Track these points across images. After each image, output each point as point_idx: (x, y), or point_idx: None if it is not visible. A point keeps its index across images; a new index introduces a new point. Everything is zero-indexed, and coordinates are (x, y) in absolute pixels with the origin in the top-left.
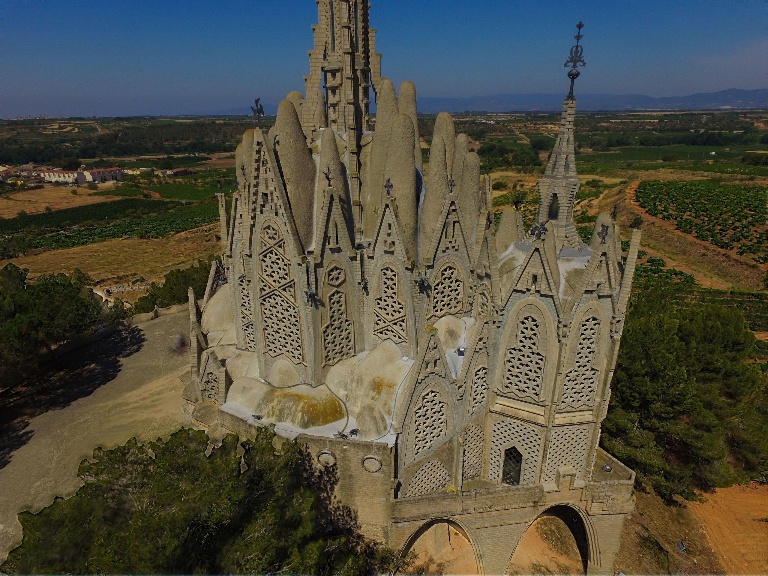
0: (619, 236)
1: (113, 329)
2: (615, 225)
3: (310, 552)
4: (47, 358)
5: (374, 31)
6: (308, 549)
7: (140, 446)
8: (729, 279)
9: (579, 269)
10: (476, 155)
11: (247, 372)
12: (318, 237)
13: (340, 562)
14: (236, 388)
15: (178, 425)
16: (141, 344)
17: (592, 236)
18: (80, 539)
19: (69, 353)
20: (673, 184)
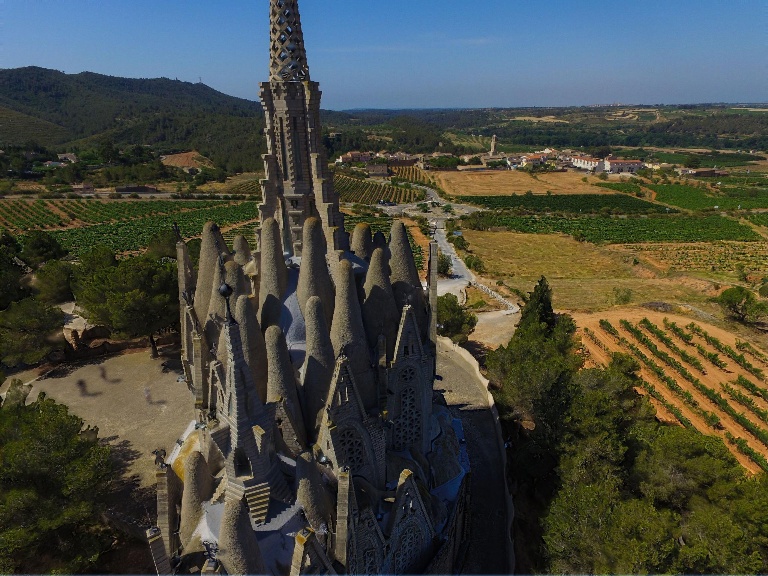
0: (299, 561)
1: None
2: (296, 539)
3: None
4: None
5: (315, 156)
6: None
7: (63, 411)
8: None
9: (200, 541)
10: (272, 331)
11: None
12: None
13: (72, 569)
14: None
15: None
16: None
17: None
18: (4, 434)
19: None
20: None
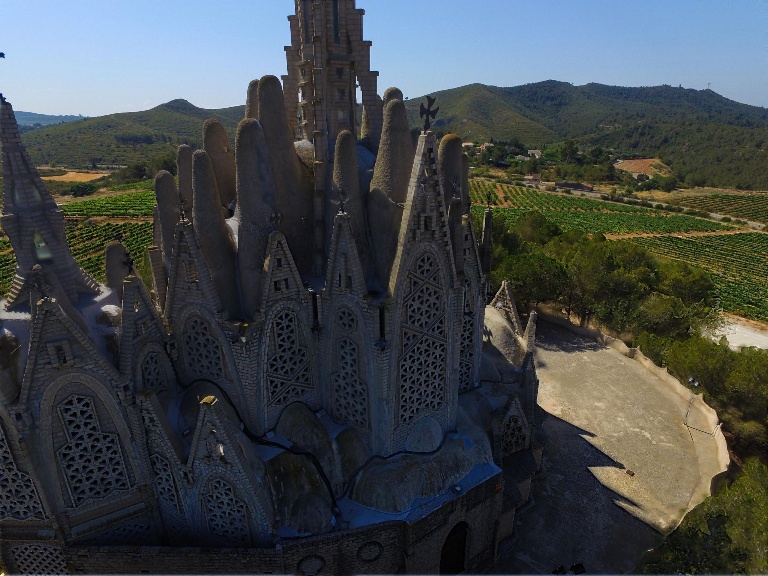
0: None
1: (595, 336)
2: None
3: None
4: (543, 316)
5: None
6: None
7: None
8: None
9: None
10: None
11: None
12: None
13: None
14: None
15: None
16: (560, 351)
17: None
18: None
19: (555, 325)
20: None
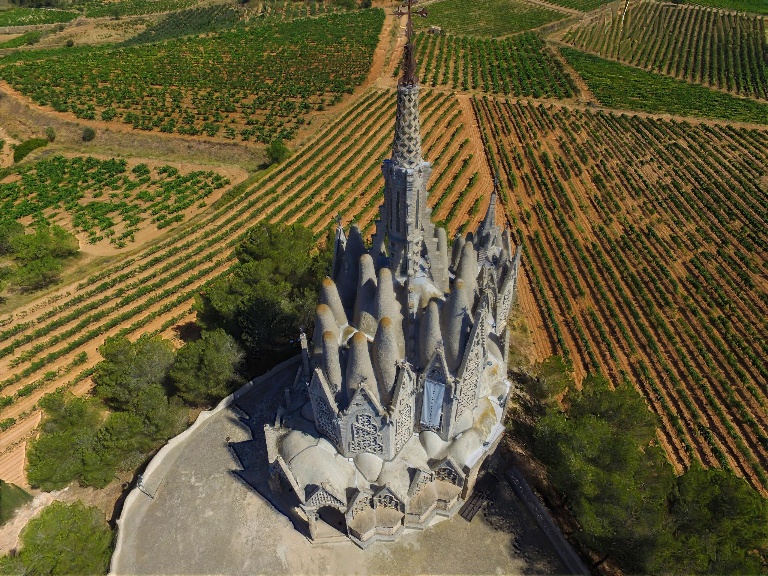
0: None
1: None
2: None
3: (586, 418)
4: None
5: None
6: (585, 419)
7: None
8: (230, 161)
9: None
10: None
11: (435, 450)
12: (486, 336)
13: None
14: (465, 452)
15: (384, 552)
16: None
17: (496, 241)
18: None
19: None
20: (37, 66)
